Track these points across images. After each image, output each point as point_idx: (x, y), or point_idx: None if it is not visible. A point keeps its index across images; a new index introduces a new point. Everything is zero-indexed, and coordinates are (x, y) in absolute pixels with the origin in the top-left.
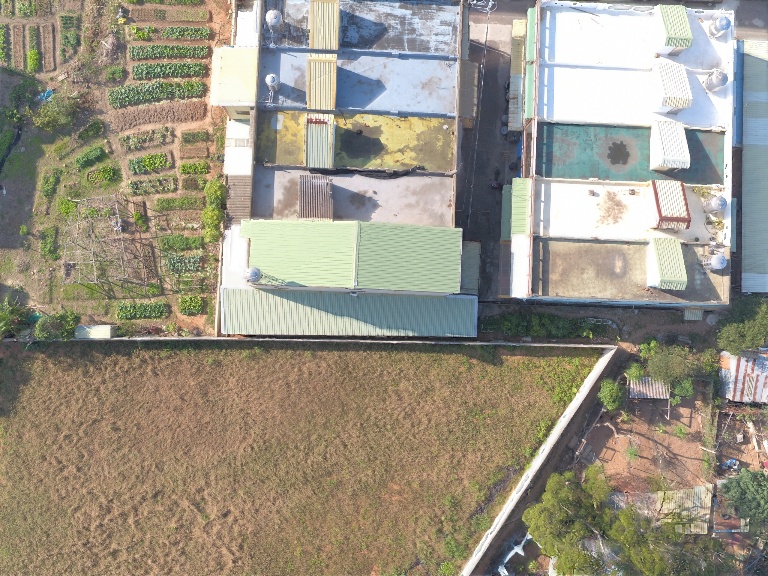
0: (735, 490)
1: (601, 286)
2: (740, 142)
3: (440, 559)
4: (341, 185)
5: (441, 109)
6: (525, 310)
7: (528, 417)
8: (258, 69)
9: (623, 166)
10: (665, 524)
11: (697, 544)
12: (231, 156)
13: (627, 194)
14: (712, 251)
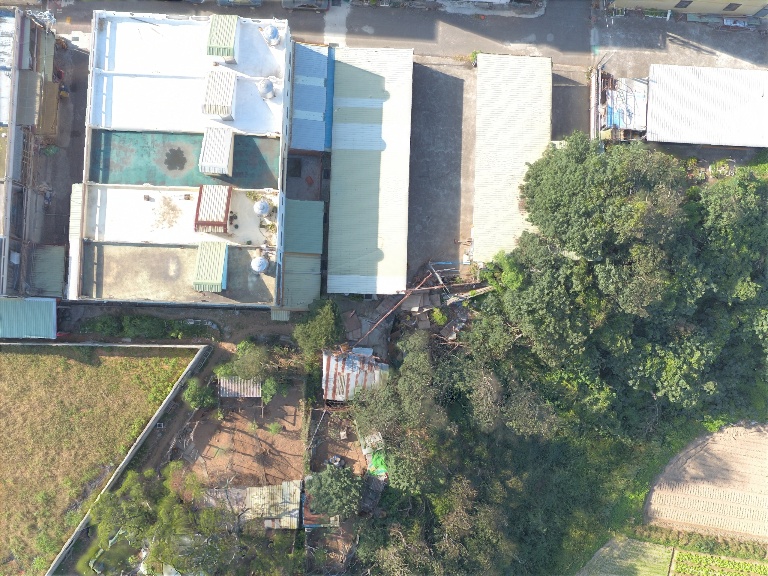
0: (315, 486)
1: (154, 288)
2: (330, 147)
3: (33, 554)
4: None
5: None
6: (126, 312)
7: (123, 416)
8: None
9: (180, 172)
10: (254, 519)
11: (290, 539)
12: None
13: (182, 199)
14: (266, 254)
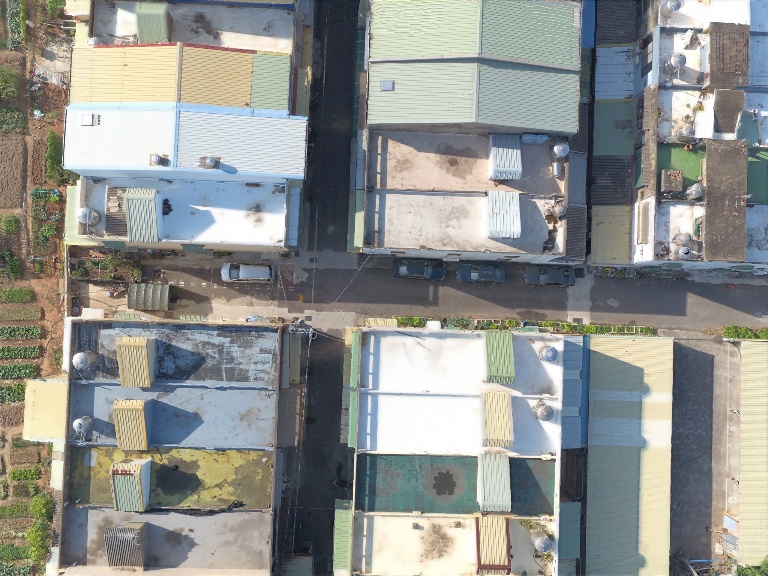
0: None
1: None
2: (586, 442)
3: None
4: (156, 523)
5: (260, 441)
6: None
7: None
8: (68, 409)
9: (449, 497)
10: None
11: None
12: (58, 470)
13: (452, 527)
14: None
